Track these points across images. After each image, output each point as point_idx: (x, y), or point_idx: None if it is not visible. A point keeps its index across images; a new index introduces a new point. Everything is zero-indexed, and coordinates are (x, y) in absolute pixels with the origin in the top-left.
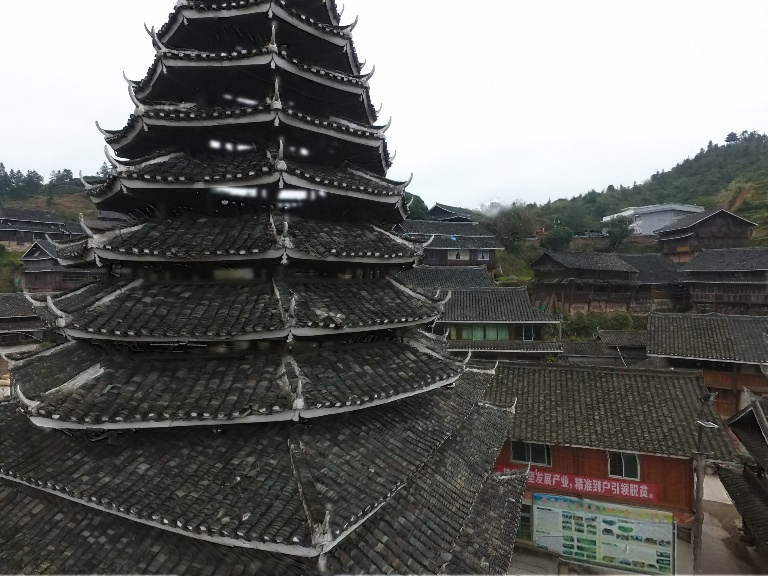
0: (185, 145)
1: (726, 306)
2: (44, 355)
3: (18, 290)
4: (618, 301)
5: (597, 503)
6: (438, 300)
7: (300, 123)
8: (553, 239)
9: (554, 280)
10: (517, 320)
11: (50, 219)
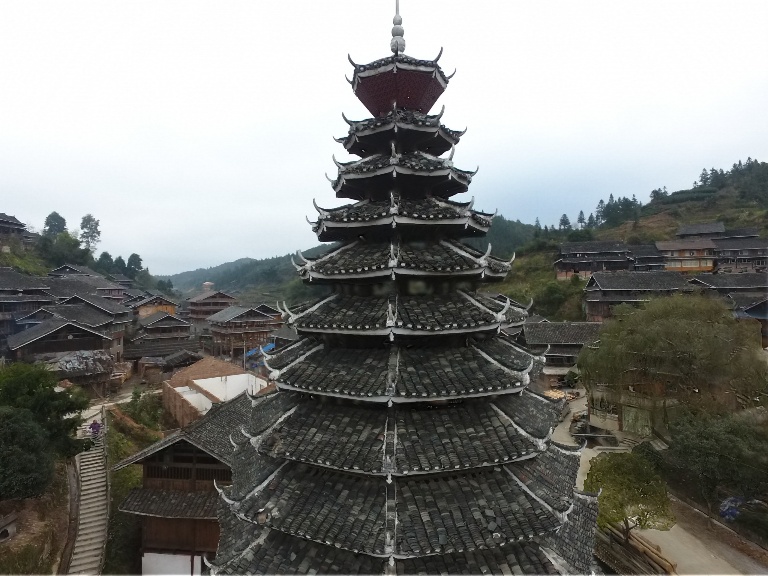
0: None
1: None
2: None
3: (582, 315)
4: None
5: None
6: None
7: (310, 329)
8: None
9: None
10: None
11: (618, 248)
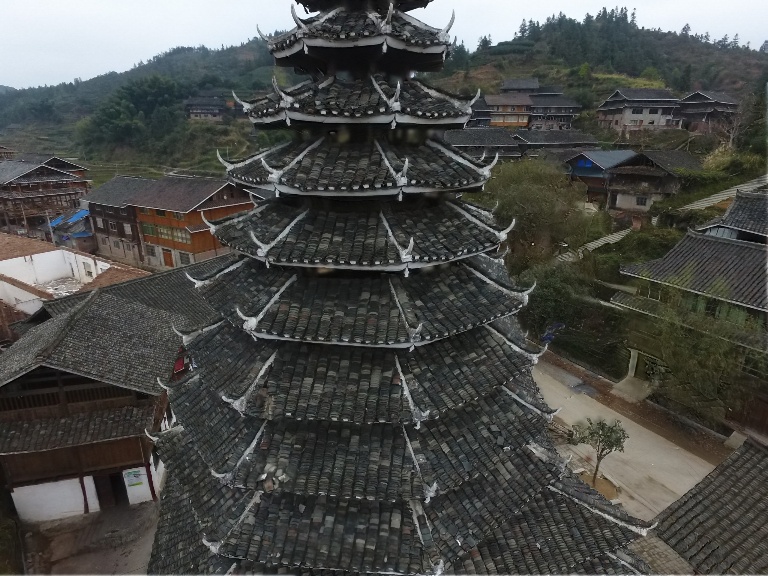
0: None
1: None
2: None
3: None
4: None
5: None
6: (426, 483)
7: (291, 263)
8: None
9: None
10: None
11: None
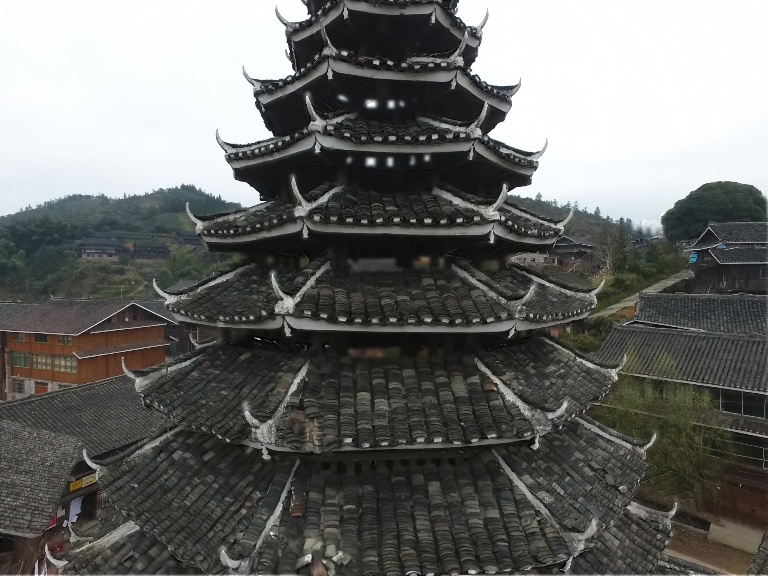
0: (249, 257)
1: None
2: None
3: None
4: None
5: None
6: (571, 529)
7: (340, 227)
8: None
9: None
10: None
11: None
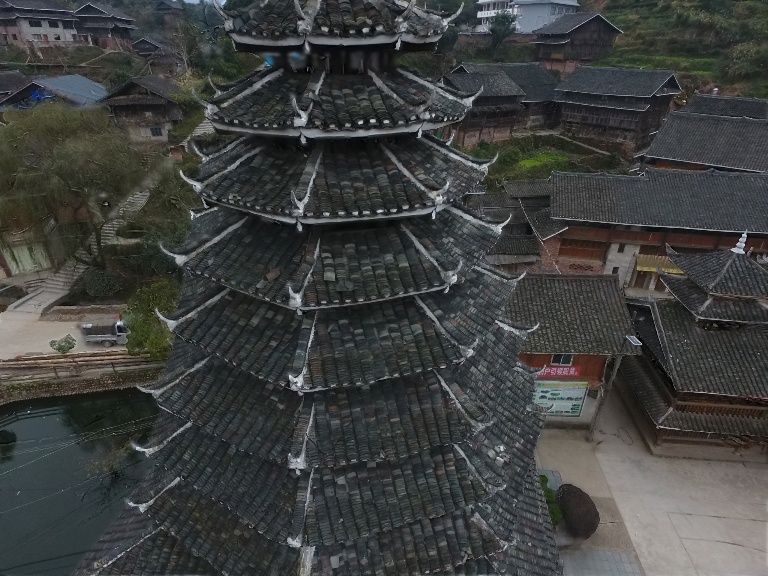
0: None
1: (588, 127)
2: (171, 487)
3: None
4: (504, 125)
5: (539, 382)
6: (534, 372)
7: None
8: (439, 40)
9: None
10: None
11: None
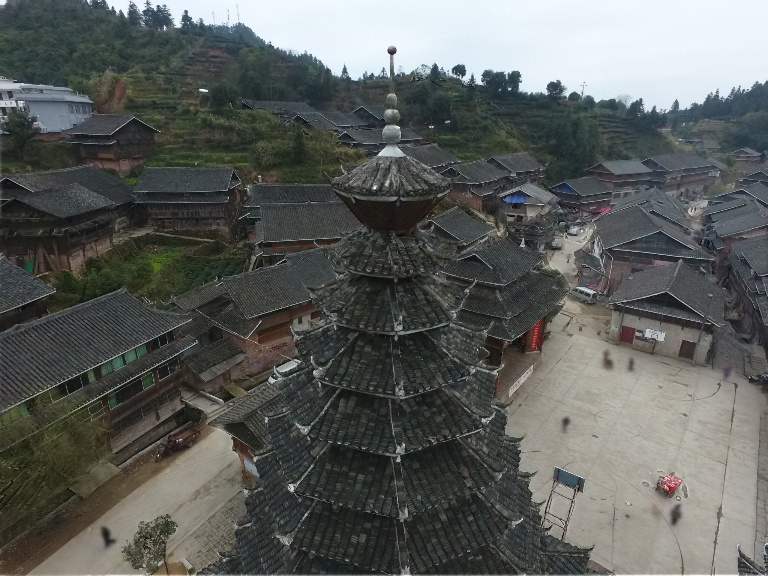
0: None
1: (181, 220)
2: None
3: None
4: (104, 237)
5: None
6: None
7: None
8: None
9: (38, 231)
10: (159, 334)
11: None
